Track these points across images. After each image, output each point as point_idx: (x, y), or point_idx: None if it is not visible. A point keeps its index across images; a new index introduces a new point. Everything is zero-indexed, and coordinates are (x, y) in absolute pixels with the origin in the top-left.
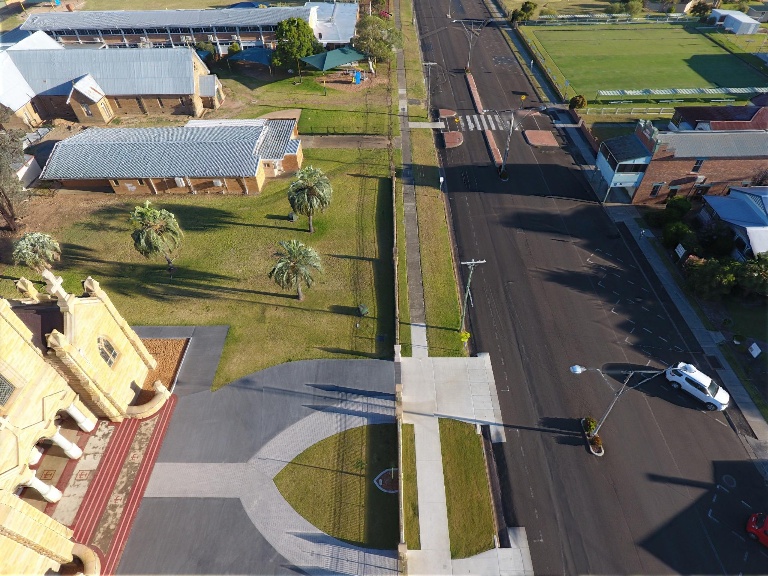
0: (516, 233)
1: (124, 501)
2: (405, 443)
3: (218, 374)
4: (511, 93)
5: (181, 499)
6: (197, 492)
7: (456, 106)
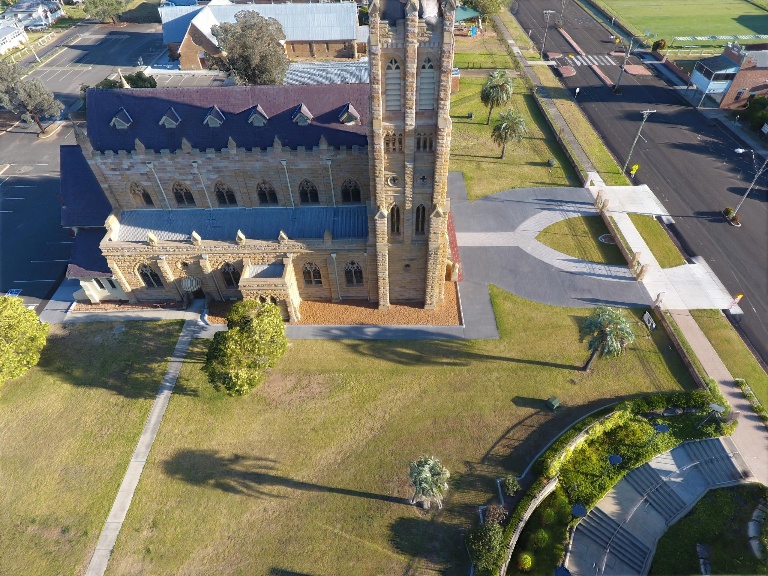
0: None
1: (449, 246)
2: None
3: (469, 194)
4: (600, 42)
5: (482, 247)
6: (490, 244)
7: (560, 50)
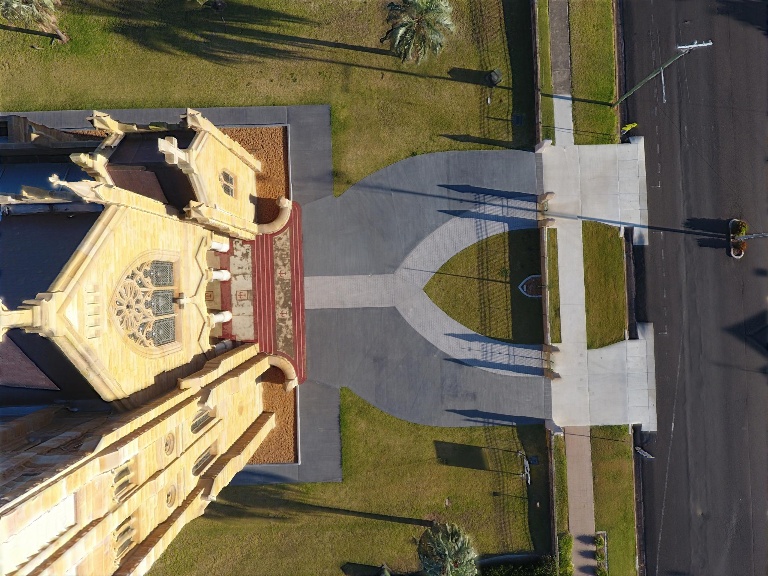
0: None
1: (290, 315)
2: (548, 249)
3: (336, 175)
4: None
5: (341, 310)
6: (354, 303)
7: None
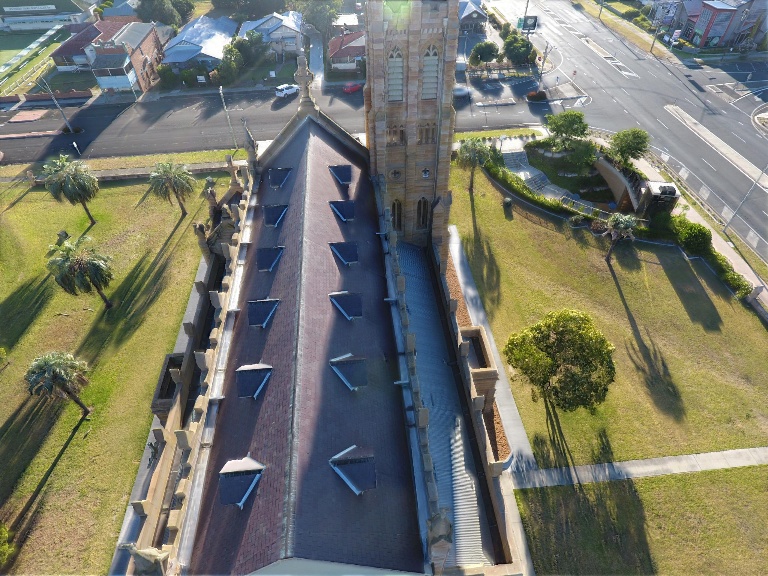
0: (154, 129)
1: None
2: None
3: None
4: None
5: None
6: None
7: None
